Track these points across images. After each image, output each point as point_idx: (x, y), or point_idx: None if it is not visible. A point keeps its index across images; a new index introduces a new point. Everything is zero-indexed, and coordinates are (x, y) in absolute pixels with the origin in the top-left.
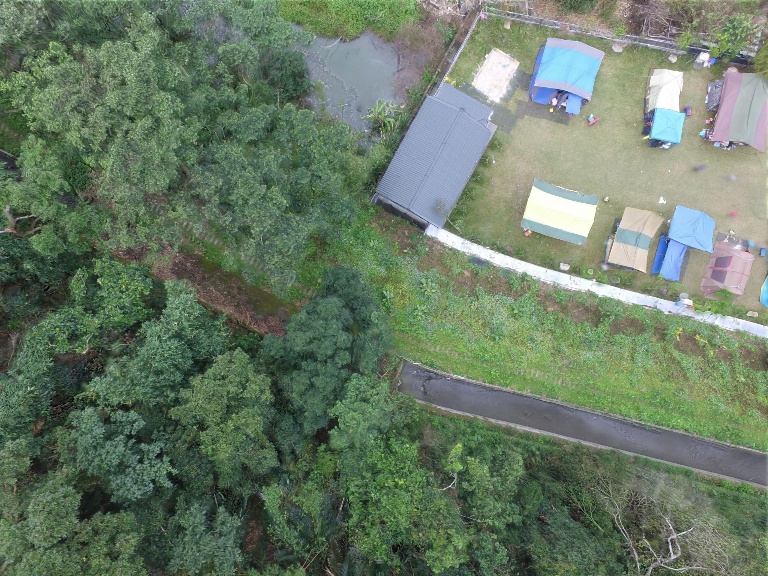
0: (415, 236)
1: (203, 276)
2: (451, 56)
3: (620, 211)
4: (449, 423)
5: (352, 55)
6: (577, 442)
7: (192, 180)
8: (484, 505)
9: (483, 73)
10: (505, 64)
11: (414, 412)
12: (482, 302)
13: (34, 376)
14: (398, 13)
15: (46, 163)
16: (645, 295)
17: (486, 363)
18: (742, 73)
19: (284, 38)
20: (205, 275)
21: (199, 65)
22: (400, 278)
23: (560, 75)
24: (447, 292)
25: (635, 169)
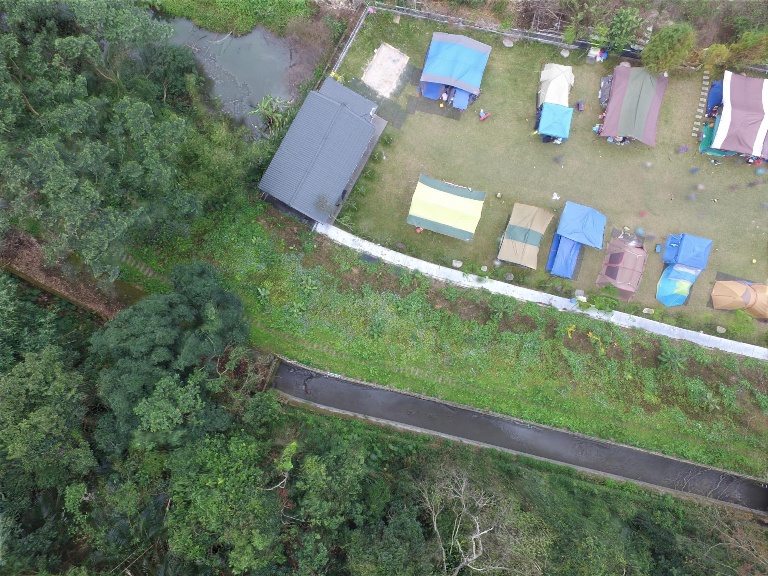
0: (304, 233)
1: (72, 273)
2: (341, 51)
3: None
4: (325, 422)
5: (244, 50)
6: (458, 441)
7: (2, 173)
8: (310, 505)
9: (373, 68)
10: (395, 59)
11: (273, 411)
12: (367, 299)
13: None
14: (288, 8)
15: None
16: (539, 292)
17: (365, 361)
18: None
19: (131, 31)
20: (74, 272)
21: (35, 58)
22: (281, 275)
23: (446, 70)
24: (330, 289)
25: (528, 165)
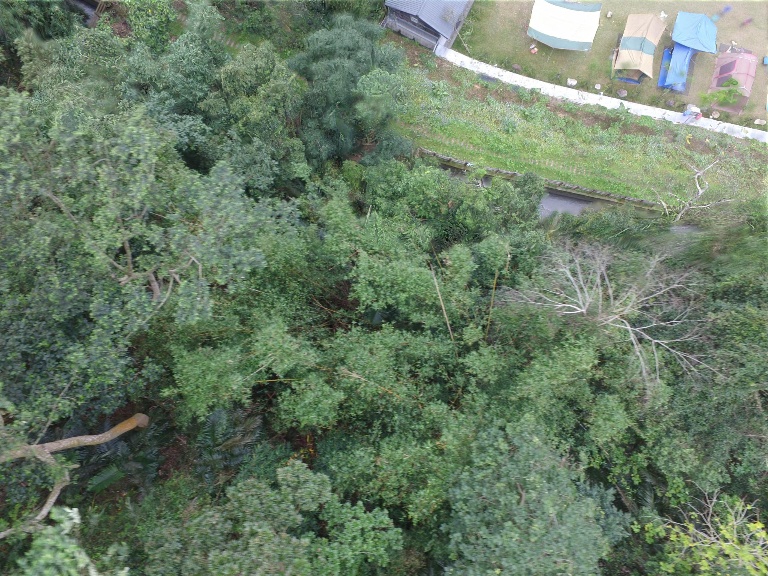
0: (424, 55)
1: None
2: None
3: (623, 26)
4: None
5: None
6: None
7: None
8: (510, 200)
9: None
10: None
11: None
12: (493, 107)
13: None
14: None
15: None
16: (653, 107)
17: (501, 155)
18: None
19: None
20: None
21: None
22: (412, 83)
23: None
24: (459, 97)
25: None
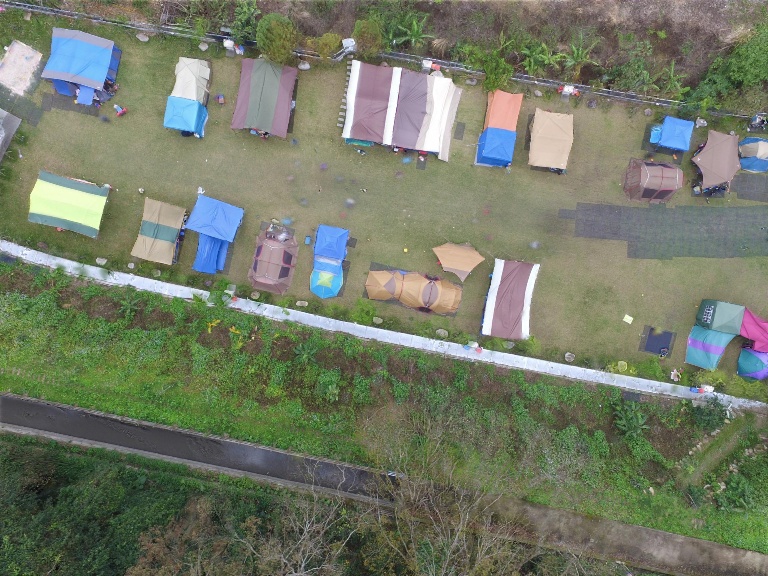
0: None
1: None
2: None
3: None
4: None
5: None
6: (65, 441)
7: None
8: None
9: (6, 66)
10: (28, 56)
11: None
12: None
13: None
14: None
15: None
16: (188, 288)
17: None
18: (253, 59)
19: None
20: None
21: None
22: None
23: (65, 65)
24: None
25: (171, 159)
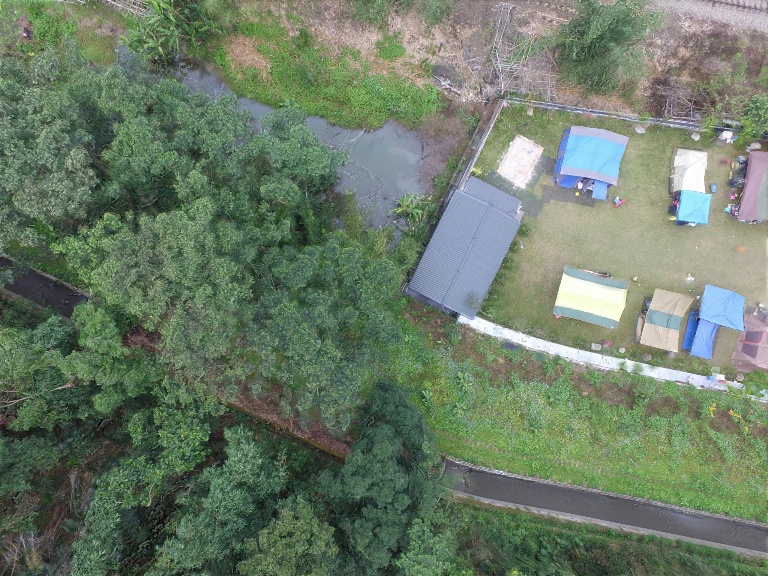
0: (447, 325)
1: (245, 386)
2: (475, 143)
3: (649, 289)
4: (493, 518)
5: (376, 145)
6: (619, 529)
7: (248, 338)
8: None
9: (508, 160)
10: (529, 150)
11: (463, 522)
12: (518, 391)
13: (103, 536)
14: (420, 103)
15: (106, 330)
16: (677, 371)
17: (526, 456)
18: (766, 152)
19: (321, 167)
20: (247, 385)
21: (242, 205)
22: (437, 373)
23: (586, 162)
24: (483, 383)
25: (662, 247)
